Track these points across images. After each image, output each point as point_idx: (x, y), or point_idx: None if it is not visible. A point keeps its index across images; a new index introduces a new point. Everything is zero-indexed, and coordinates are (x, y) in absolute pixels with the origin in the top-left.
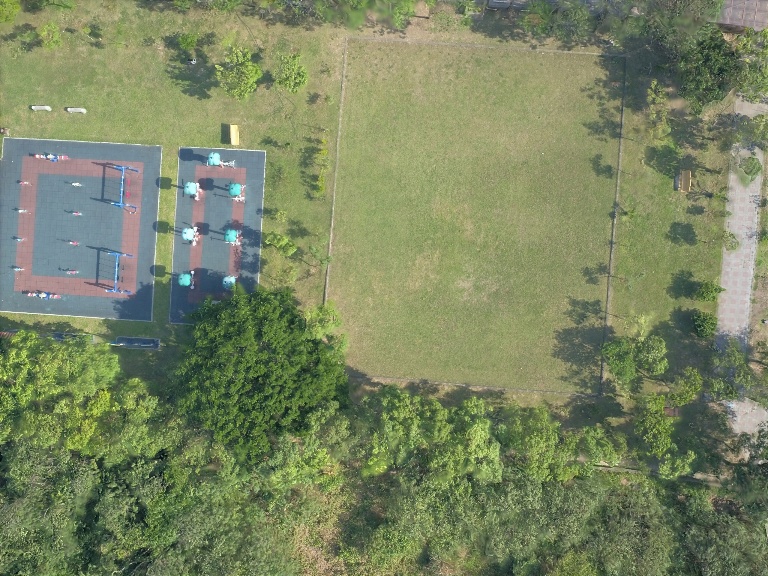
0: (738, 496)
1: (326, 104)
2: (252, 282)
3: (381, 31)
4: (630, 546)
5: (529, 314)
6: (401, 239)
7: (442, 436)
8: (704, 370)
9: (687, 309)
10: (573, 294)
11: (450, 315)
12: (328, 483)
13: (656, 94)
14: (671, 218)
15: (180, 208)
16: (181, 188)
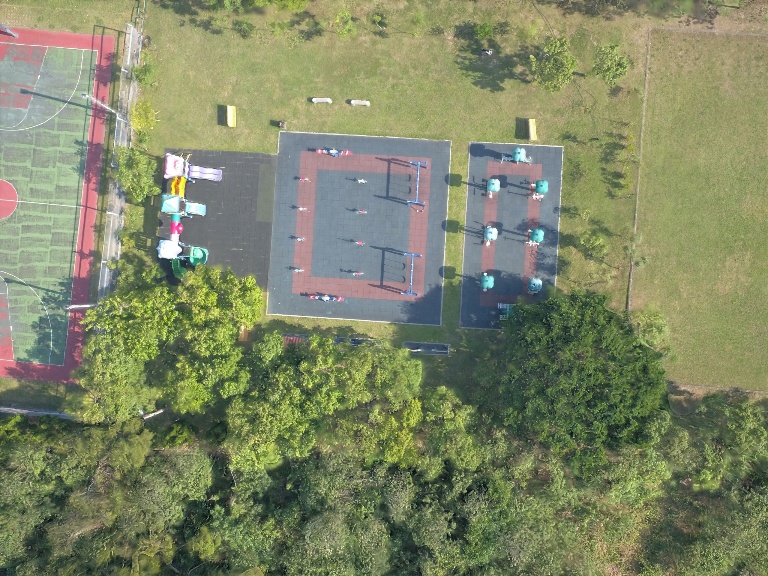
0: None
1: (629, 97)
2: (548, 284)
3: (687, 21)
4: None
5: None
6: (710, 240)
7: None
8: None
9: None
10: None
11: (762, 320)
12: (639, 497)
13: None
14: None
15: (471, 206)
16: (472, 185)
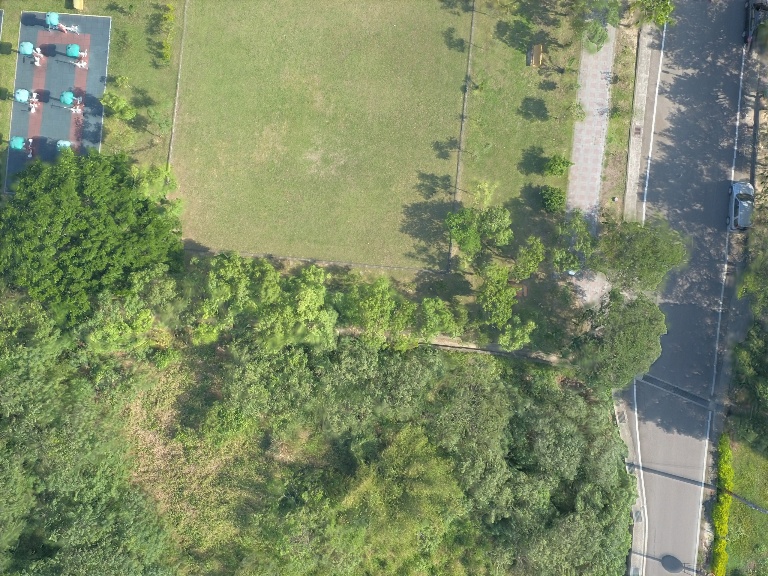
0: None
1: None
2: (93, 152)
3: None
4: (465, 415)
5: (377, 188)
6: (248, 109)
7: (270, 296)
8: (552, 246)
9: (538, 186)
10: (423, 168)
11: (296, 188)
12: (163, 357)
13: None
14: (523, 93)
15: (20, 74)
16: None
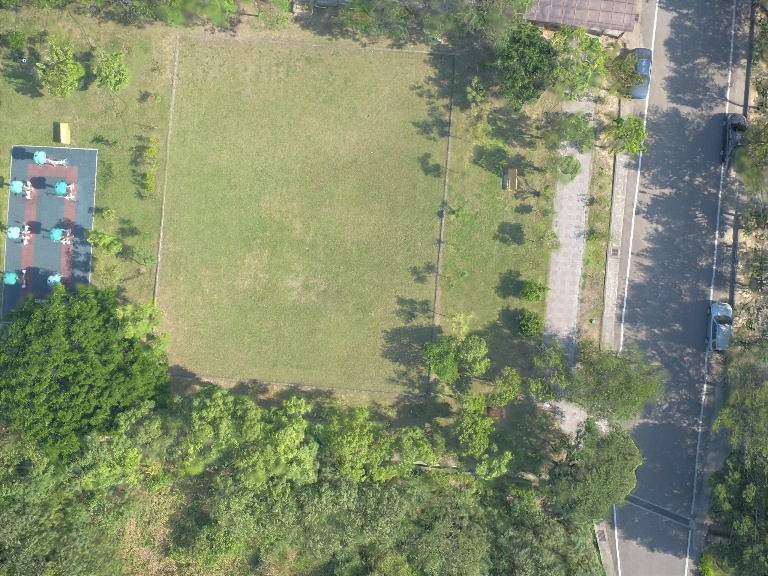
0: None
1: None
2: (83, 281)
3: (212, 29)
4: (442, 547)
5: (357, 313)
6: (230, 238)
7: (250, 436)
8: (530, 370)
9: (515, 309)
10: (401, 293)
11: (279, 314)
12: (153, 483)
13: (477, 92)
14: (499, 217)
15: (12, 207)
16: None
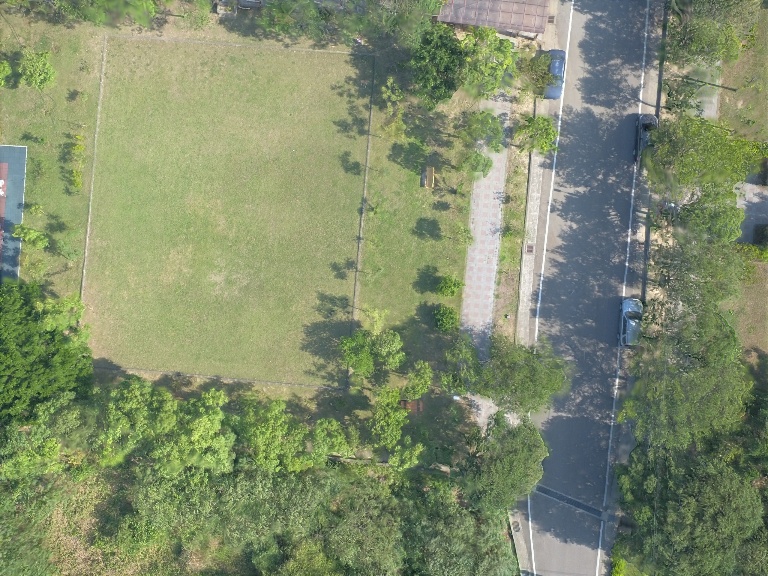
0: None
1: (85, 101)
2: (13, 275)
3: (139, 29)
4: (352, 536)
5: (278, 308)
6: (155, 234)
7: (165, 426)
8: None
9: (432, 304)
10: (321, 288)
11: (202, 308)
12: (77, 473)
13: (392, 92)
14: (417, 214)
15: None
16: None
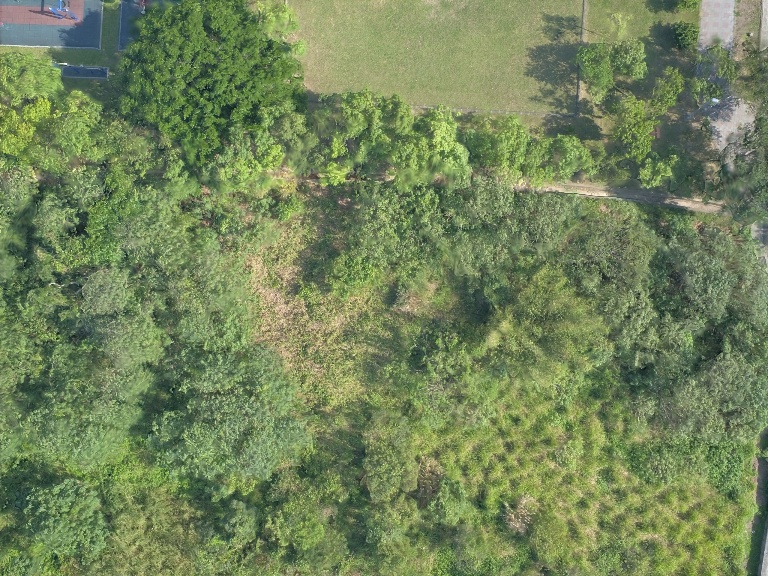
0: (725, 222)
1: None
2: None
3: None
4: (609, 247)
5: (500, 31)
6: None
7: (405, 126)
8: (686, 84)
9: (668, 24)
10: (547, 9)
11: (416, 34)
12: (286, 208)
13: None
14: None
15: None
16: None
